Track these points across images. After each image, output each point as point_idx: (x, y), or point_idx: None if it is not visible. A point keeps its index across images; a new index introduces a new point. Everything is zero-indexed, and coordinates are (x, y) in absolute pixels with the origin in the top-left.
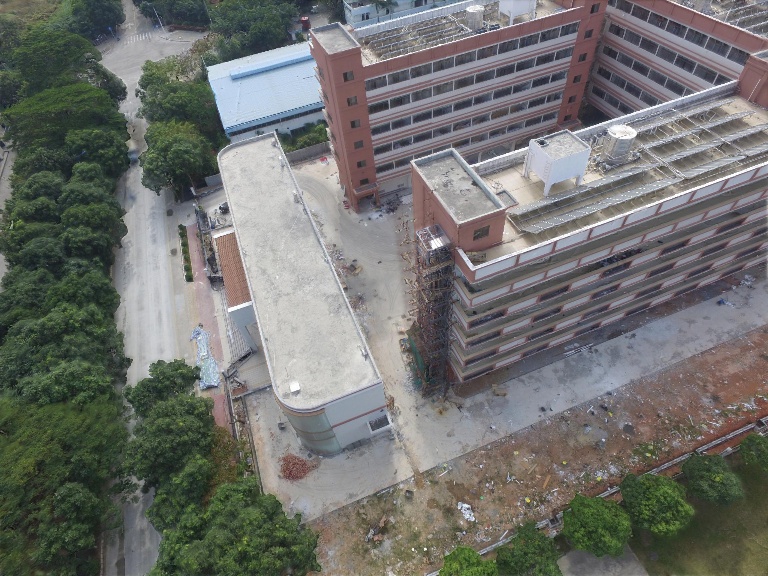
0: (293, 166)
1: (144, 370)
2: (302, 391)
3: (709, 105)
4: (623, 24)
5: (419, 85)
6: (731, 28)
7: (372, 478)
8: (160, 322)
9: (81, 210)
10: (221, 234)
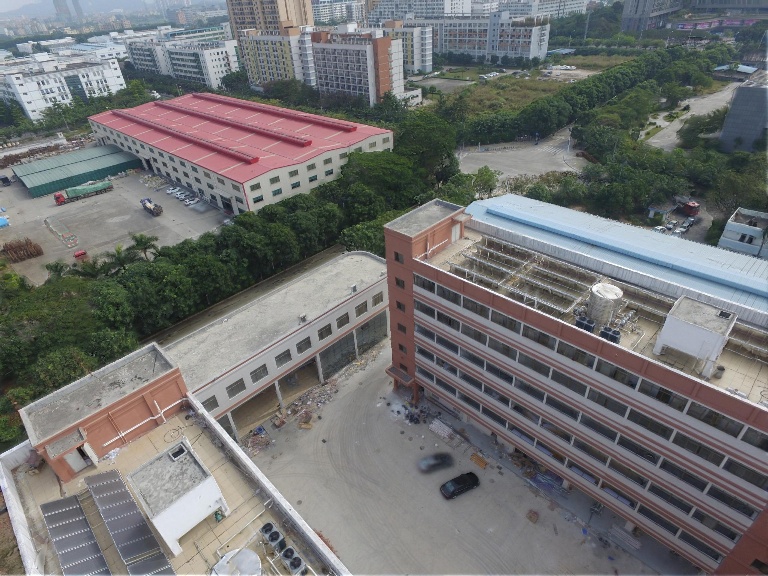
0: None
1: None
2: None
3: None
4: None
5: (471, 321)
6: None
7: None
8: None
9: (280, 228)
10: None
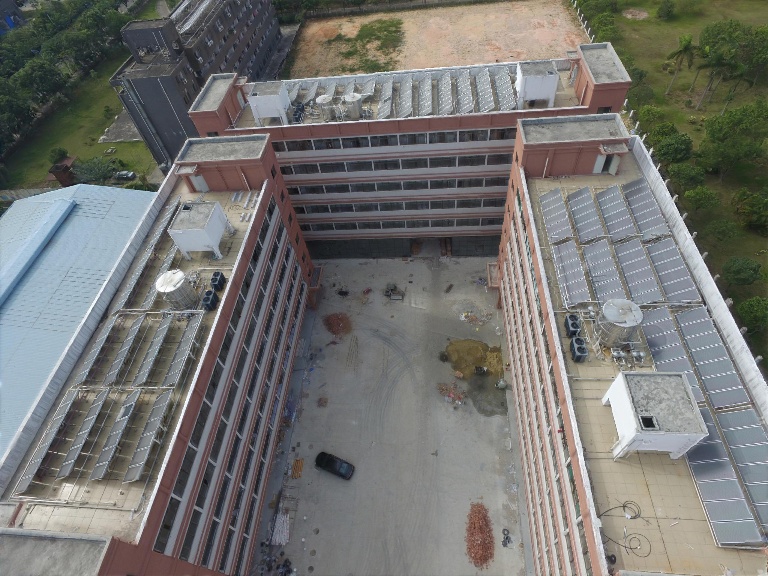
0: None
1: None
2: None
3: (546, 206)
4: (284, 163)
5: (210, 438)
6: (418, 120)
7: None
8: None
9: None
10: None
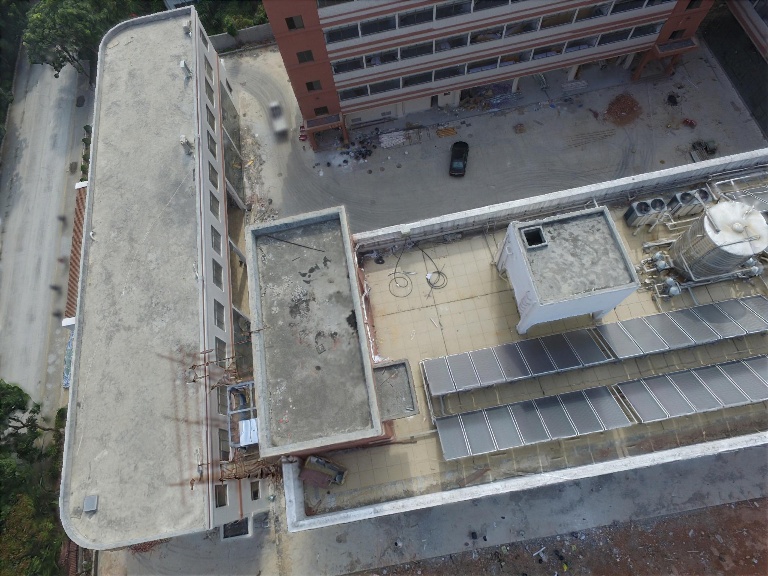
0: (248, 51)
1: (7, 342)
2: (100, 511)
3: None
4: None
5: None
6: None
7: (228, 575)
8: (37, 274)
9: None
10: (86, 183)
